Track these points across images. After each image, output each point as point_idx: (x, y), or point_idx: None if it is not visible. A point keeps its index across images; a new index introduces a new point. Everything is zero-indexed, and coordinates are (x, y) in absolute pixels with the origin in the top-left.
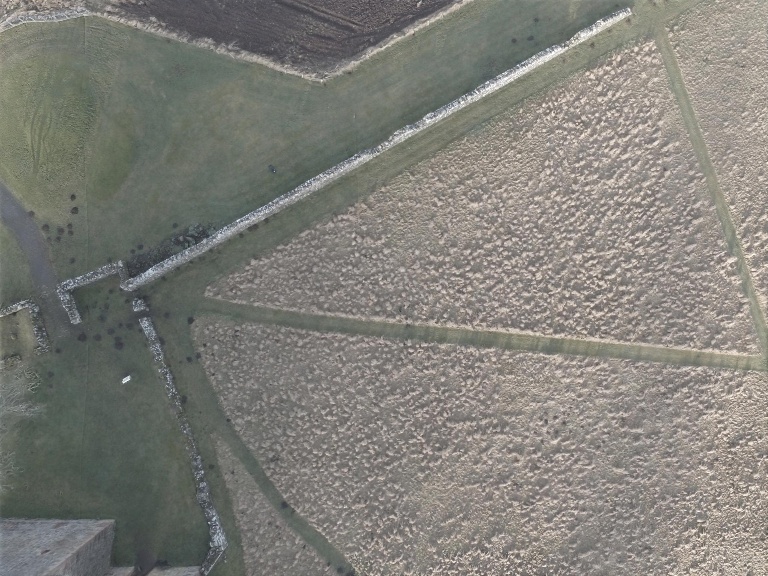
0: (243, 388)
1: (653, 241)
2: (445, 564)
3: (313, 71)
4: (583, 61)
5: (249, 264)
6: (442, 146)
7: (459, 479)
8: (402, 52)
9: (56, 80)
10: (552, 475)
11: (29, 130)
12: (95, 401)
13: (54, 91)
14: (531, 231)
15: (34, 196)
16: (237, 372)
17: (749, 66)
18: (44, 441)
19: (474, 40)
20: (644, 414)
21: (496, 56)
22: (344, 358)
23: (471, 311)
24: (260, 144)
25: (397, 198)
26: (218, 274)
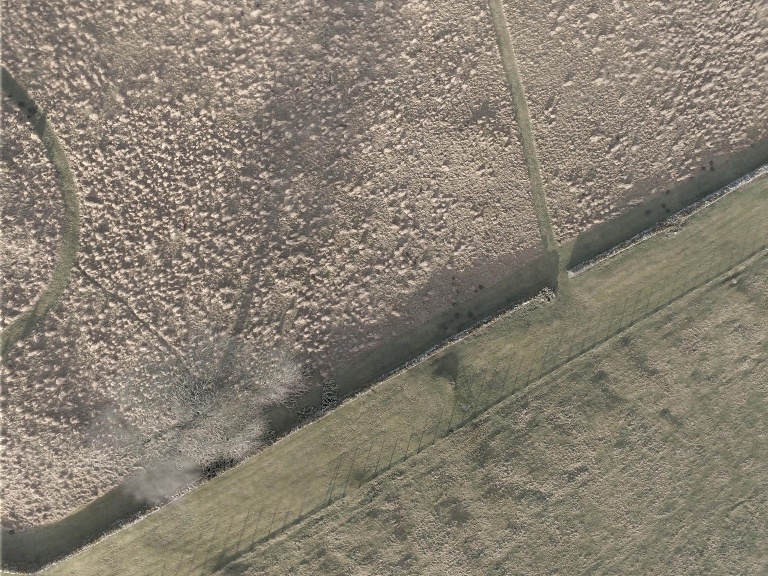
0: None
1: None
2: (133, 116)
3: None
4: None
5: None
6: None
7: (155, 40)
8: None
9: None
10: (250, 46)
11: None
12: None
13: None
14: None
15: None
16: None
17: None
18: None
19: None
20: None
21: None
22: None
23: None
24: None
25: None
26: None
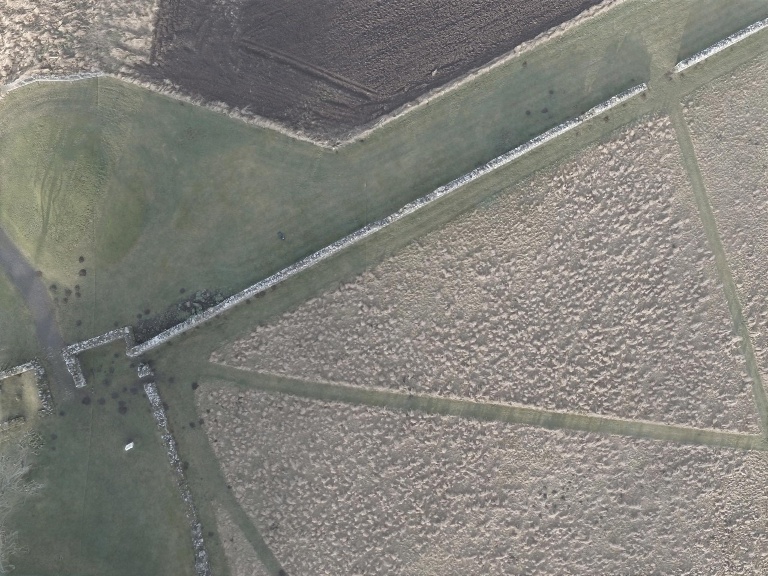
0: (245, 455)
1: (659, 318)
2: None
3: (325, 138)
4: (596, 134)
5: (255, 331)
6: (452, 217)
7: (456, 551)
8: (415, 121)
9: (68, 141)
10: (549, 549)
11: (39, 191)
12: (97, 465)
13: (65, 153)
14: (537, 305)
15: (42, 256)
16: (239, 439)
17: (763, 143)
18: (46, 504)
19: (488, 111)
20: (643, 491)
21: (509, 128)
22: (346, 427)
23: (475, 384)
24: (270, 210)
25: (405, 268)
26: (224, 340)
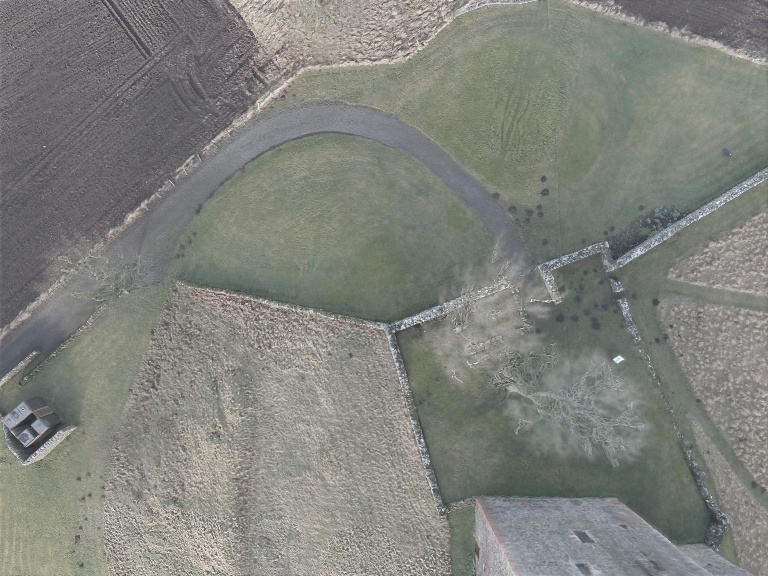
0: (709, 369)
1: None
2: None
3: (761, 55)
4: None
5: (707, 246)
6: None
7: None
8: None
9: (529, 62)
10: None
11: (502, 112)
12: None
13: (529, 73)
14: None
15: (501, 178)
16: (703, 353)
17: None
18: (537, 420)
19: None
20: None
21: None
22: None
23: None
24: (713, 127)
25: None
26: (678, 256)
